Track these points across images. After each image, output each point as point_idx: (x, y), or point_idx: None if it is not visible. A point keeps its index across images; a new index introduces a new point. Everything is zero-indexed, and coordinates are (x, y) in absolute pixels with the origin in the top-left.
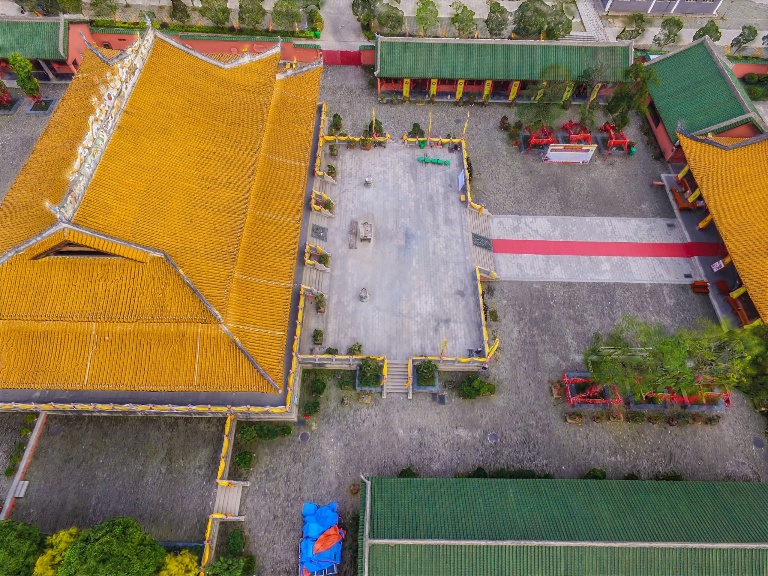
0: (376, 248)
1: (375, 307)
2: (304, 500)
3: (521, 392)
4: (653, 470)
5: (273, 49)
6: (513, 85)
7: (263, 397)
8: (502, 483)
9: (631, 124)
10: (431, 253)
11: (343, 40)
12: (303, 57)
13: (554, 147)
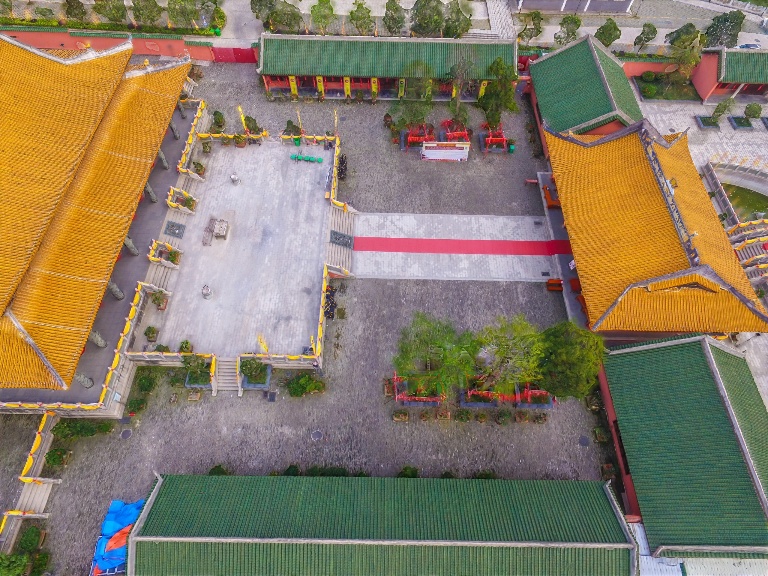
0: (231, 245)
1: (218, 304)
2: (113, 497)
3: (354, 390)
4: (472, 468)
5: (123, 45)
6: (399, 83)
7: (82, 394)
8: (297, 481)
9: (518, 122)
10: (285, 250)
11: (244, 38)
12: (197, 54)
13: (427, 145)
